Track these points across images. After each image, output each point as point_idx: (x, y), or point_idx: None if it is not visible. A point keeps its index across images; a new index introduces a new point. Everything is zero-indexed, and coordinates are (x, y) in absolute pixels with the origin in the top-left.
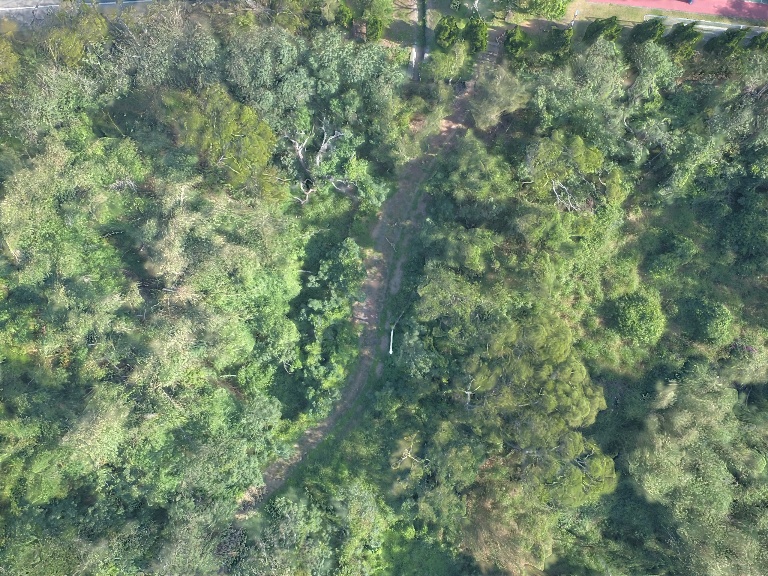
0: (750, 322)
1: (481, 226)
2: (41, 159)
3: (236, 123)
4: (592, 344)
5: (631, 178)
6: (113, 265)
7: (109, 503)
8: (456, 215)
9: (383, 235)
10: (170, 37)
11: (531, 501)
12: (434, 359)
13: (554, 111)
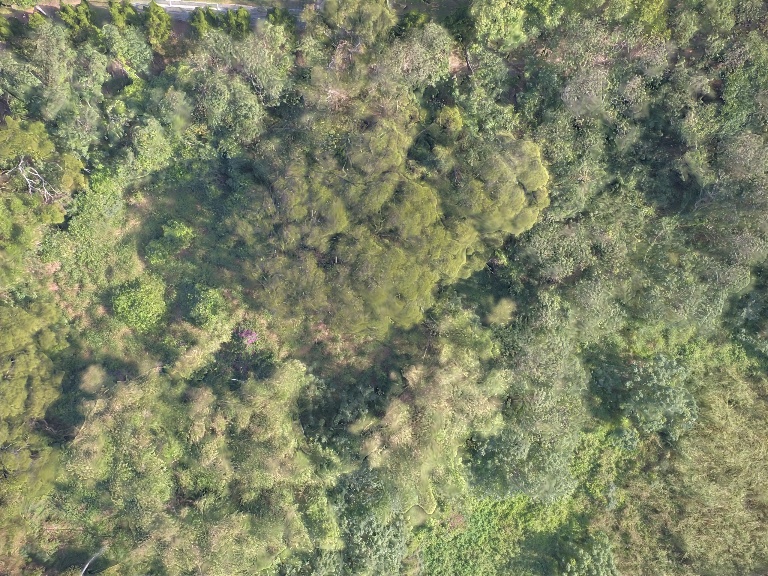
0: (252, 305)
1: None
2: None
3: None
4: (95, 332)
5: None
6: None
7: None
8: None
9: None
10: None
11: (3, 493)
12: None
13: (19, 97)
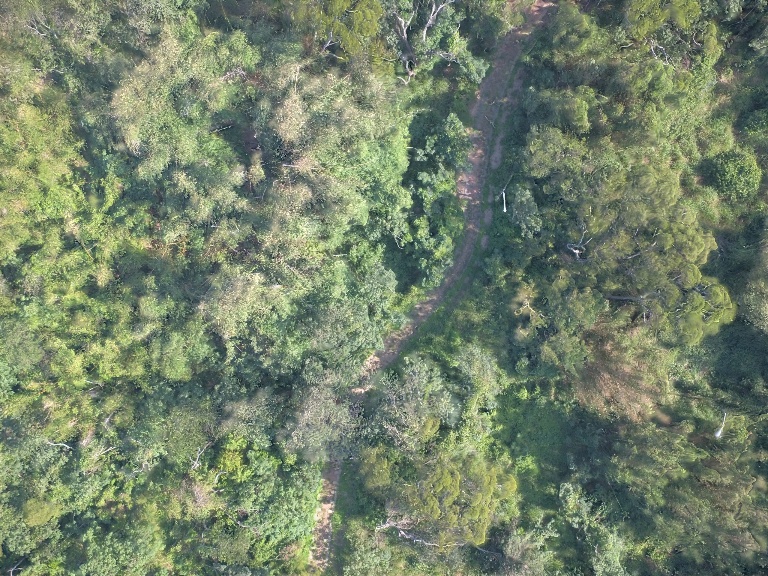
0: None
1: None
2: (148, 64)
3: None
4: (692, 201)
5: (721, 41)
6: (227, 154)
7: (232, 382)
8: (559, 80)
9: (482, 113)
10: None
11: None
12: (542, 221)
13: None
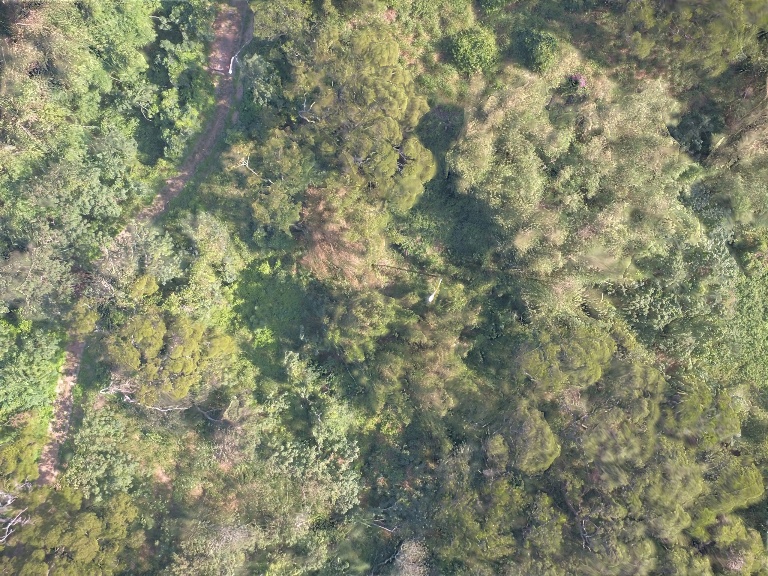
0: (579, 54)
1: None
2: None
3: None
4: (430, 78)
5: None
6: None
7: None
8: None
9: None
10: None
11: None
12: (277, 89)
13: None
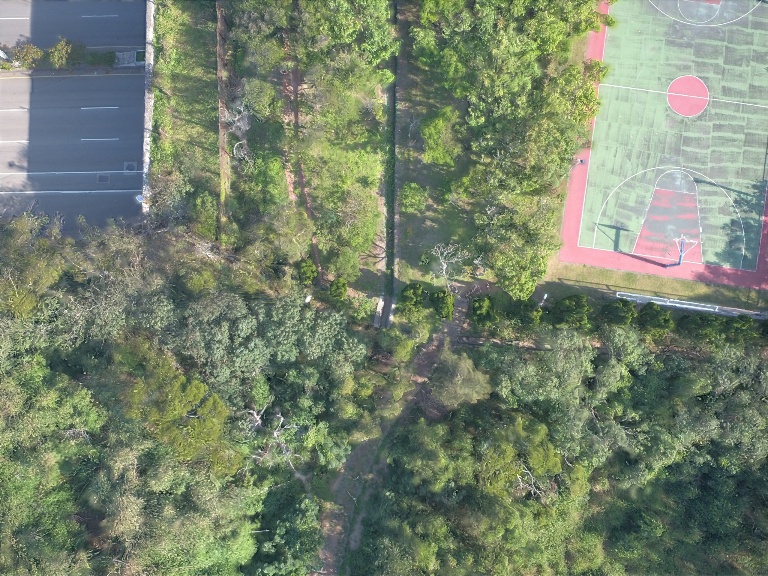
0: None
1: (441, 511)
2: None
3: (190, 404)
4: None
5: None
6: (67, 511)
7: None
8: (416, 494)
9: (345, 488)
10: (128, 295)
11: None
12: None
13: (519, 396)
